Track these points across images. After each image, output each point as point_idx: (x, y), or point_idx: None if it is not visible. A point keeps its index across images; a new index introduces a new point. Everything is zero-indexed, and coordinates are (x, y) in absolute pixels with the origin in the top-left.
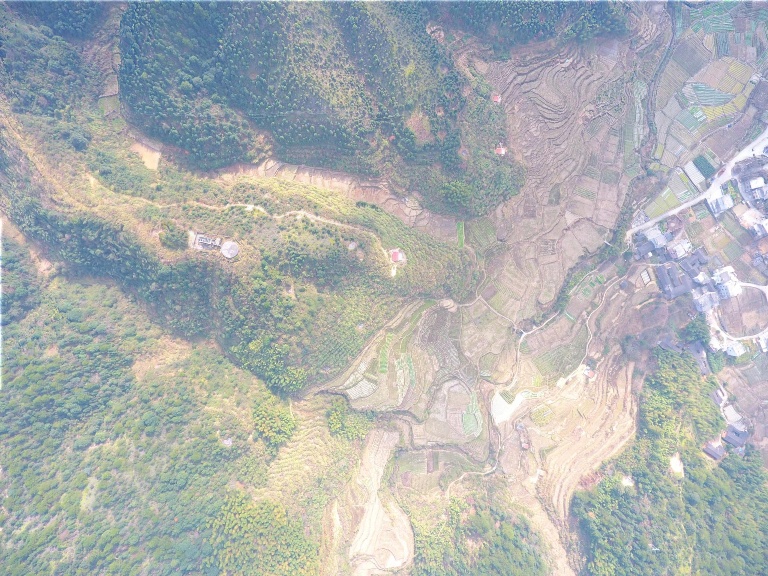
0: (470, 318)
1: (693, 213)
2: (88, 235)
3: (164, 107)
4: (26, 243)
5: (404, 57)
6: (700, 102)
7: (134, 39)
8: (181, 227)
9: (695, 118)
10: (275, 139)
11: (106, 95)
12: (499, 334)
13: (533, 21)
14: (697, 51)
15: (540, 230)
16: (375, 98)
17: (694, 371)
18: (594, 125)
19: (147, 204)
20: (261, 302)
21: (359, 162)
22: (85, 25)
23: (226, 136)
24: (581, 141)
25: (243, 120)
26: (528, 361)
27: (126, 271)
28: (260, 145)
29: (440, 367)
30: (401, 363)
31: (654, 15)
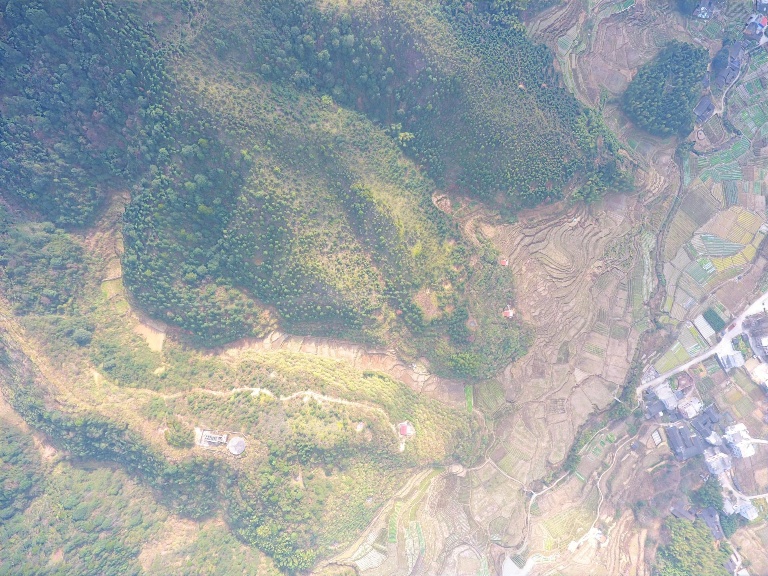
0: (479, 482)
1: (704, 368)
2: (93, 432)
3: (168, 298)
4: (30, 430)
5: (411, 239)
6: (709, 253)
7: (137, 236)
8: (187, 425)
9: (704, 270)
10: (281, 315)
11: (109, 279)
12: (509, 497)
13: (540, 190)
14: (705, 201)
15: (549, 389)
16: (381, 273)
17: (708, 542)
18: (602, 280)
19: (152, 398)
20: (269, 496)
21: (366, 335)
22: (87, 217)
23: (231, 319)
24: (589, 297)
25: (248, 300)
26: (539, 524)
27: (131, 459)
28: (265, 321)
29: (450, 533)
30: (410, 532)
31: (662, 166)
